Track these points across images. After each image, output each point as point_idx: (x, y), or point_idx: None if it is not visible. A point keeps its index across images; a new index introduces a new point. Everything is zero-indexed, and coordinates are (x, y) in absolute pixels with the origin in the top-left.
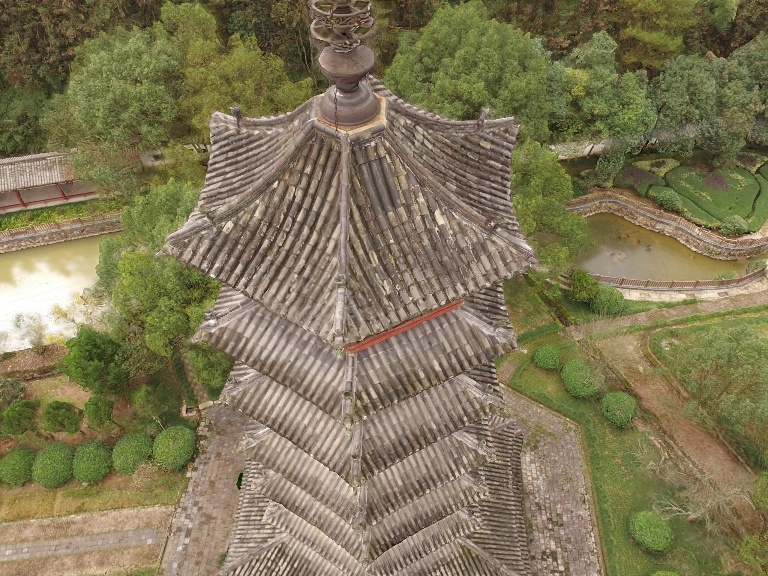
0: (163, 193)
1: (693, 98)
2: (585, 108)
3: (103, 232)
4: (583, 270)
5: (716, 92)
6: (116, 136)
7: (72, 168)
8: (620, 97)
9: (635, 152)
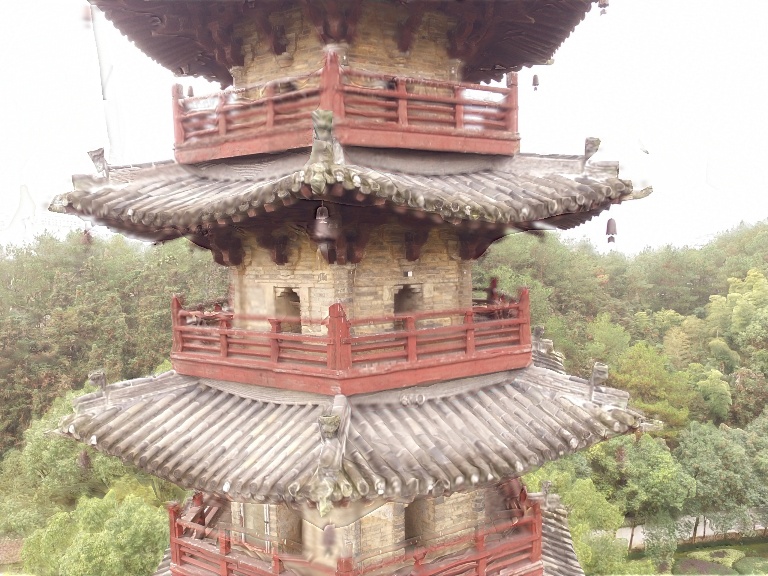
0: (94, 504)
1: (726, 463)
2: (610, 466)
3: None
4: None
5: (748, 460)
6: (62, 467)
7: None
8: (645, 458)
9: (685, 536)
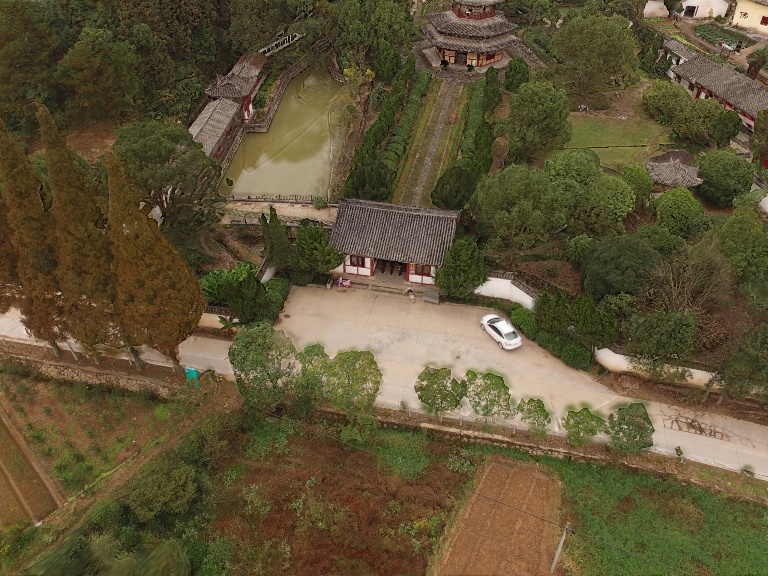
0: None
1: None
2: None
3: None
4: None
5: None
6: None
7: (255, 65)
8: None
9: None
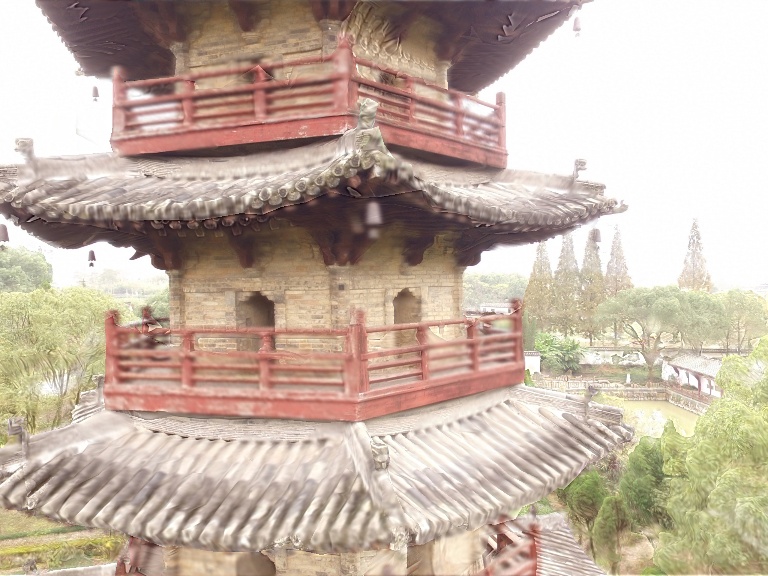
0: None
1: None
2: None
3: None
4: None
5: None
6: None
7: None
8: None
9: None
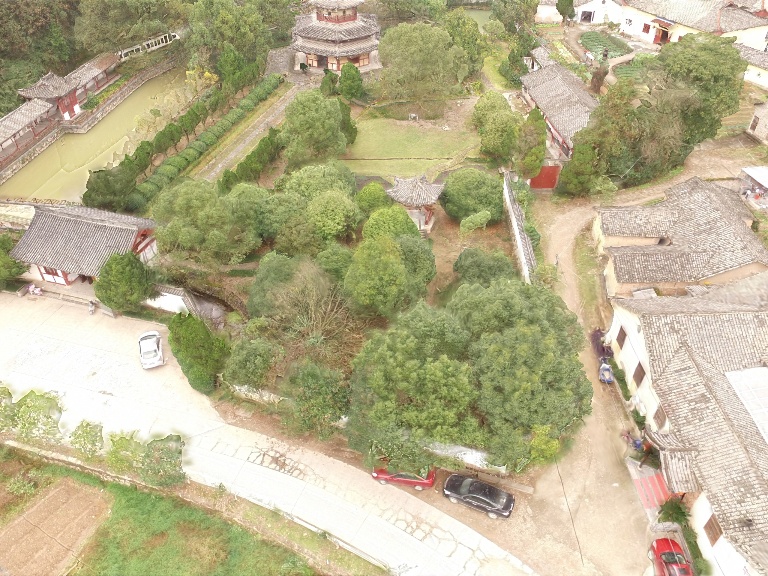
0: None
1: None
2: None
3: (133, 91)
4: (291, 11)
5: None
6: None
7: (99, 66)
8: None
9: None
